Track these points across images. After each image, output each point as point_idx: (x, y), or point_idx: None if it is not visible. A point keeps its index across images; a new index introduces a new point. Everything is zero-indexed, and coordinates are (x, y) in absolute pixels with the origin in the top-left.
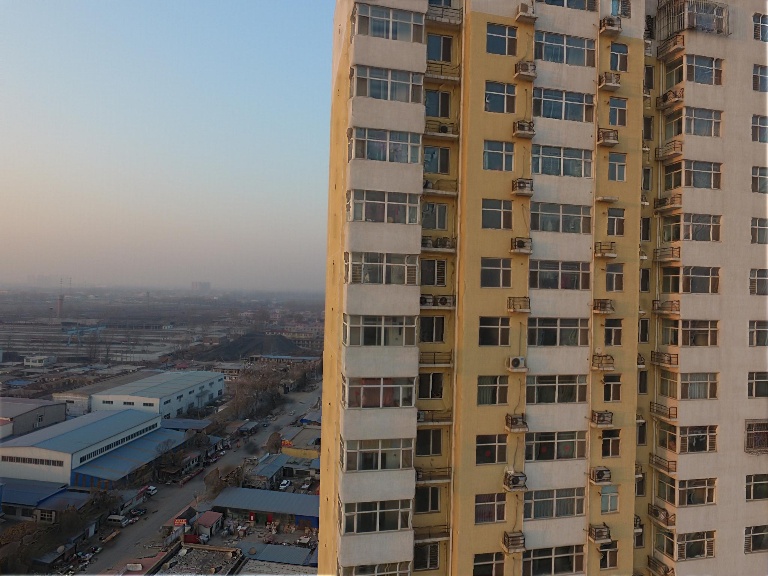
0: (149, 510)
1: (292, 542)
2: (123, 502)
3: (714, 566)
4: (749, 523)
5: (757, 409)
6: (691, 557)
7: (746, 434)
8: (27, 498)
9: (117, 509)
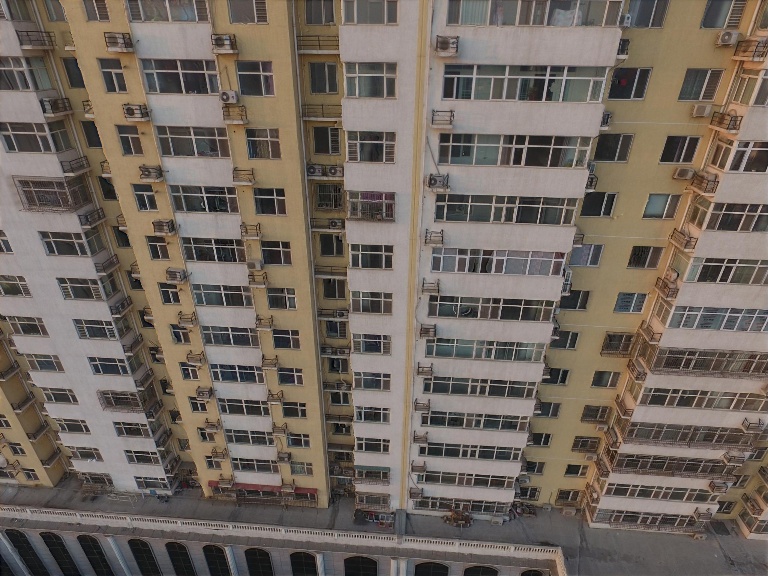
0: None
1: None
2: None
3: (34, 304)
4: (58, 274)
5: (23, 165)
6: (12, 295)
7: (21, 191)
8: None
9: None
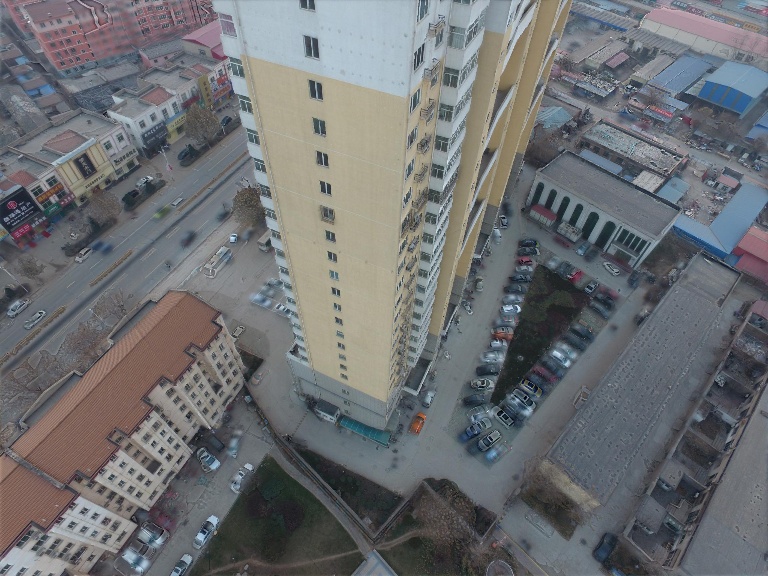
0: (764, 174)
1: (696, 215)
2: (762, 155)
3: None
4: None
5: None
6: None
7: None
8: (765, 121)
9: (757, 156)
